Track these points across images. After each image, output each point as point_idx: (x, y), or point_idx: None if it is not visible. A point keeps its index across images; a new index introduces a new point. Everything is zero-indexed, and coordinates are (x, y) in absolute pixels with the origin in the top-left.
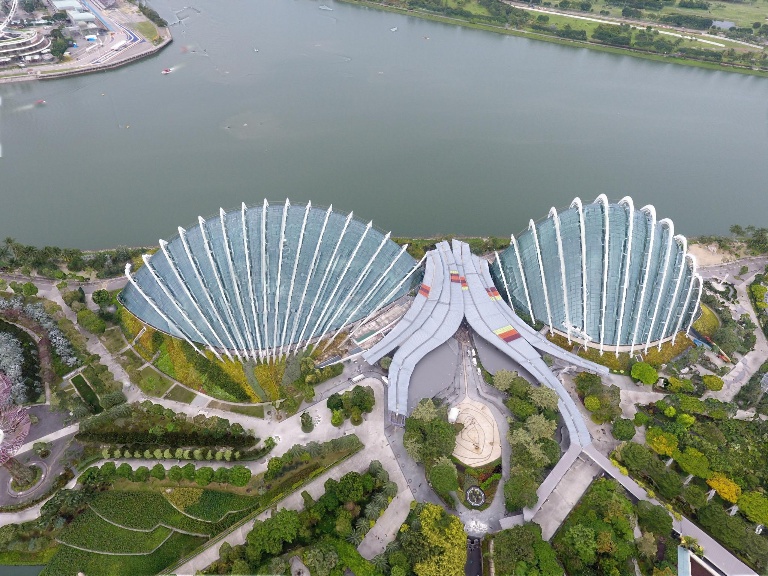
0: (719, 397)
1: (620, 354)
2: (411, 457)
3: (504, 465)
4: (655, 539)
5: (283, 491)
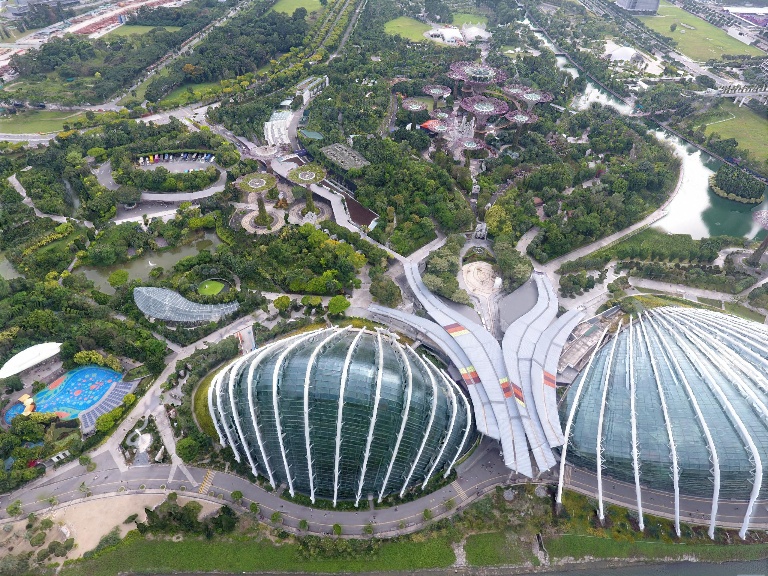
0: None
1: None
2: None
3: (461, 262)
4: None
5: None
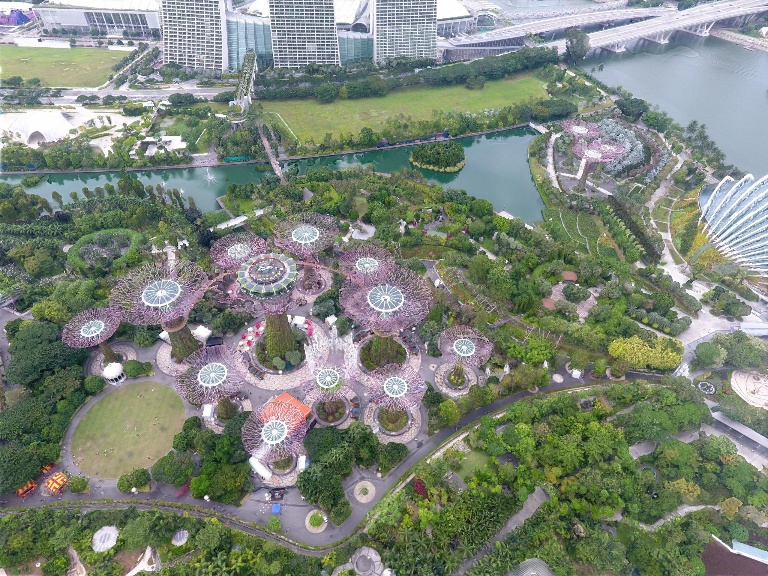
0: None
1: None
2: None
3: None
4: (767, 535)
5: (636, 282)
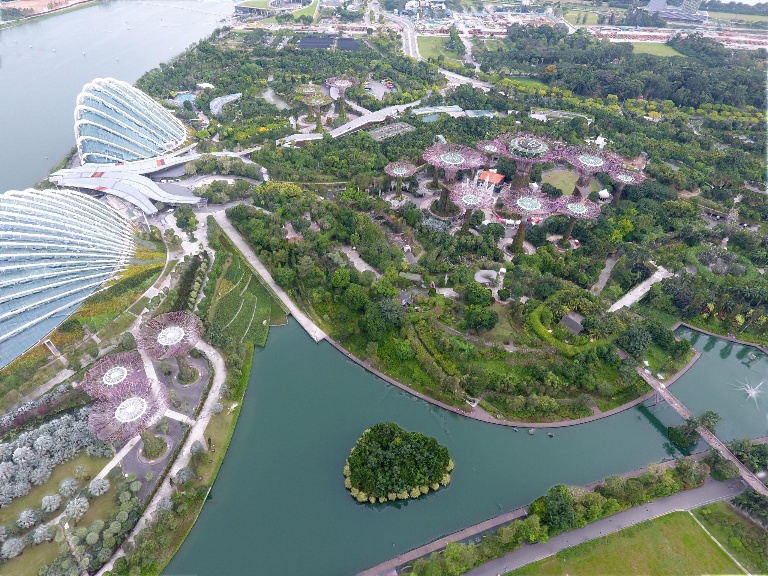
0: None
1: (187, 140)
2: (225, 205)
3: None
4: None
5: None
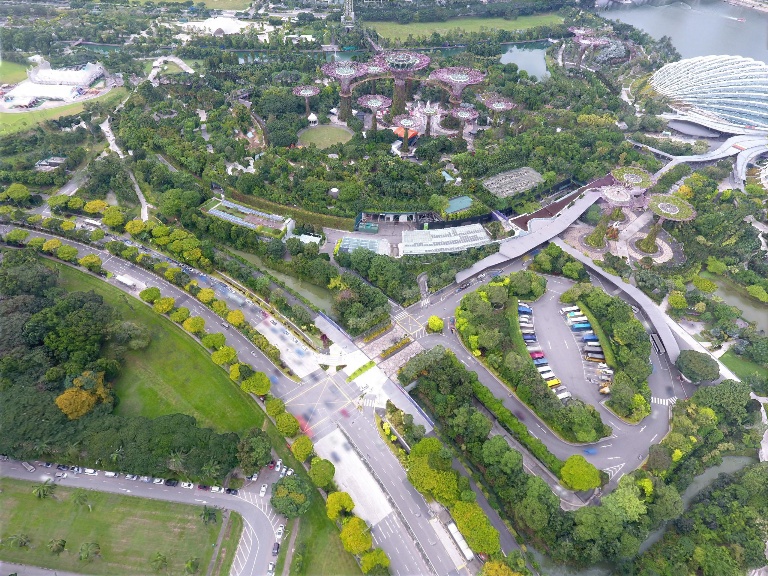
0: (766, 230)
1: (766, 190)
2: None
3: None
4: None
5: None
